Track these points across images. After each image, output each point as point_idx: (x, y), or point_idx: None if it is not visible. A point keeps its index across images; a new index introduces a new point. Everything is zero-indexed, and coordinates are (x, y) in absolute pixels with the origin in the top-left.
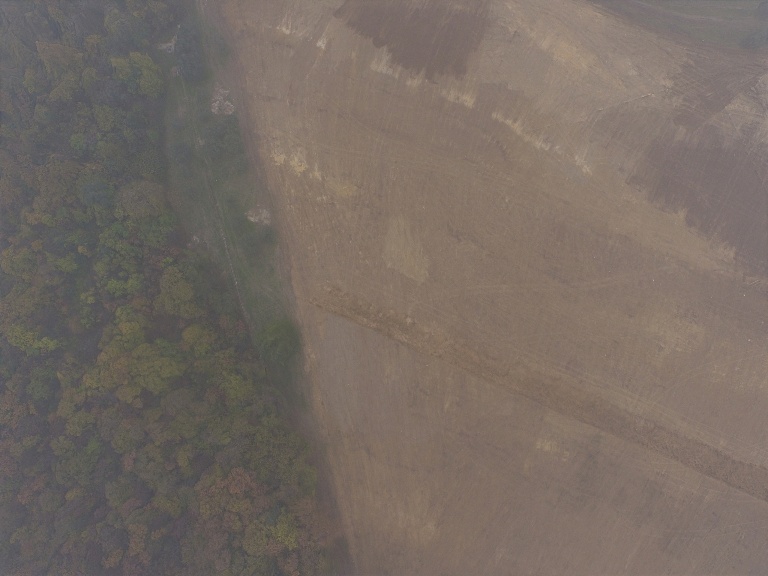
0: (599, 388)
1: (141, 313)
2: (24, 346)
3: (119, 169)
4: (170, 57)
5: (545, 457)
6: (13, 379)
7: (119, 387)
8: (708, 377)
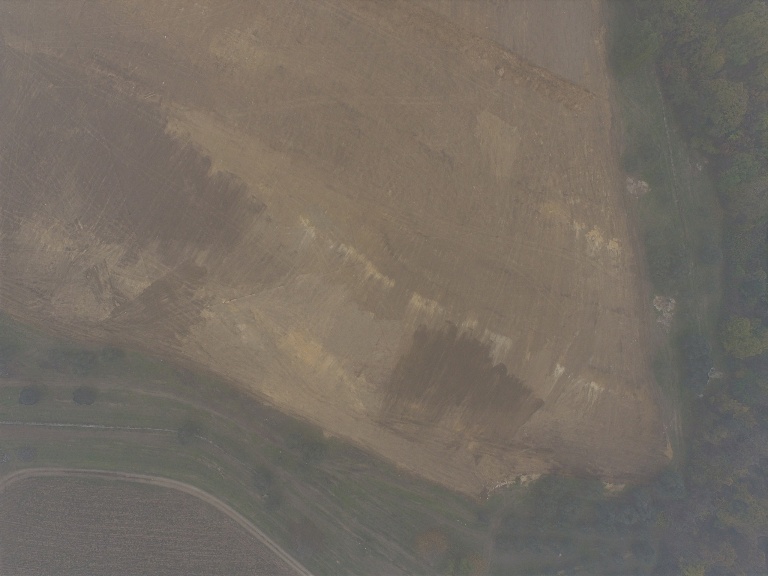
0: None
1: (761, 87)
2: None
3: None
4: None
5: None
6: None
7: None
8: (212, 3)
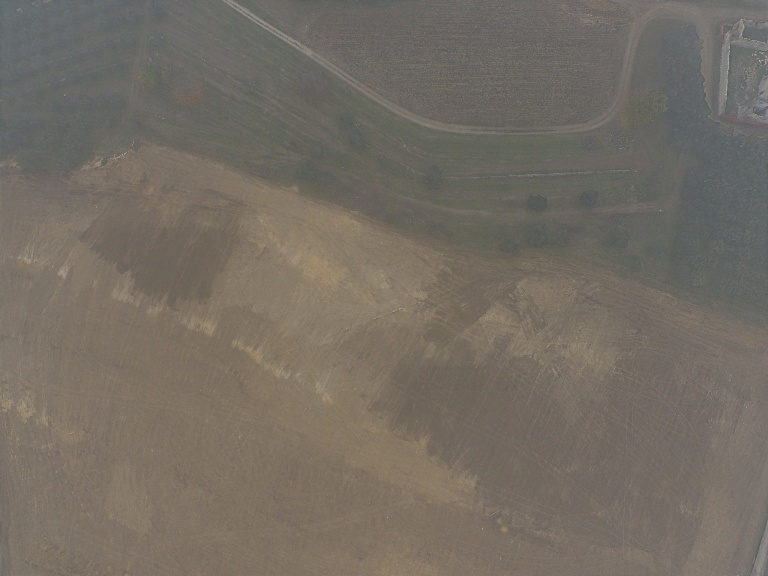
0: None
1: None
2: None
3: None
4: None
5: None
6: None
7: None
8: None
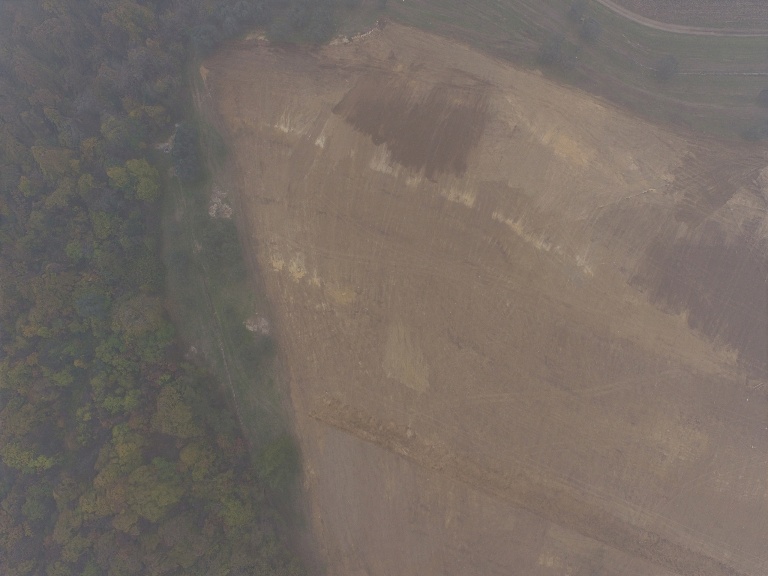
0: (602, 500)
1: (138, 433)
2: (19, 465)
3: (116, 278)
4: (167, 157)
5: (548, 573)
6: (8, 499)
7: (116, 515)
8: (712, 486)
